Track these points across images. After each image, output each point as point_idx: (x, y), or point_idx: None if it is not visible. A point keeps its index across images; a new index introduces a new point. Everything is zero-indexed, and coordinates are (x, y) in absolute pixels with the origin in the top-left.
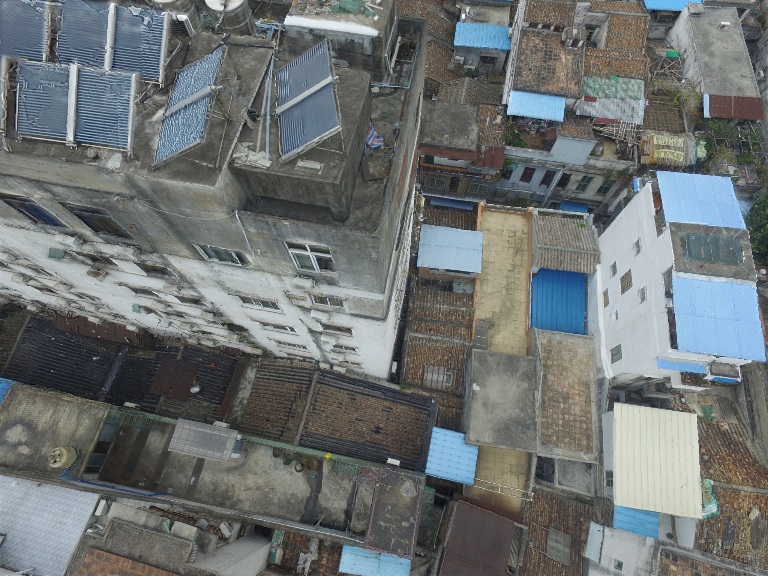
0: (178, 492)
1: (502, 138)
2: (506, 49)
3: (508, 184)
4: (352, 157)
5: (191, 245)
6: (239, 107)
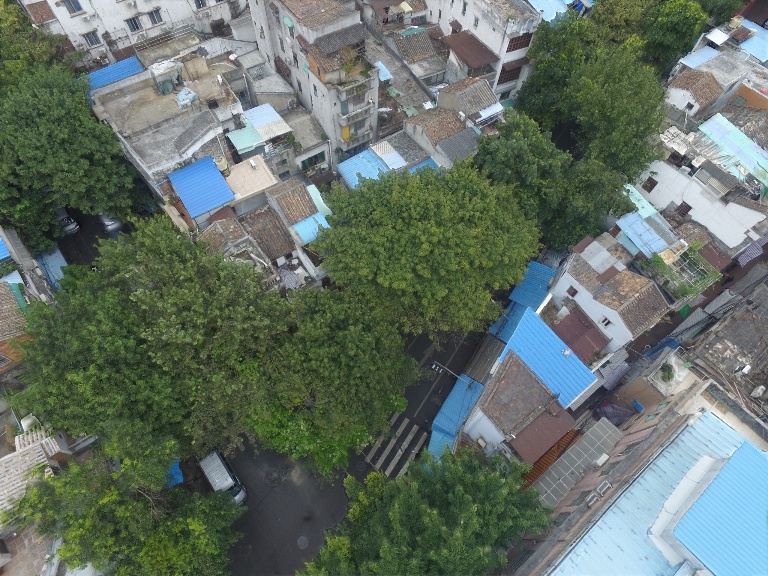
0: None
1: None
2: None
3: None
4: None
5: None
6: None
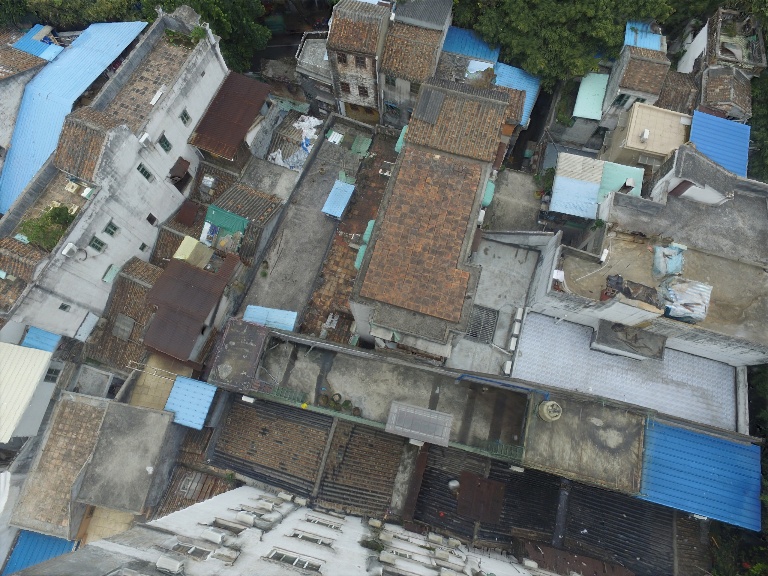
0: (449, 381)
1: None
2: None
3: None
4: None
5: None
6: None
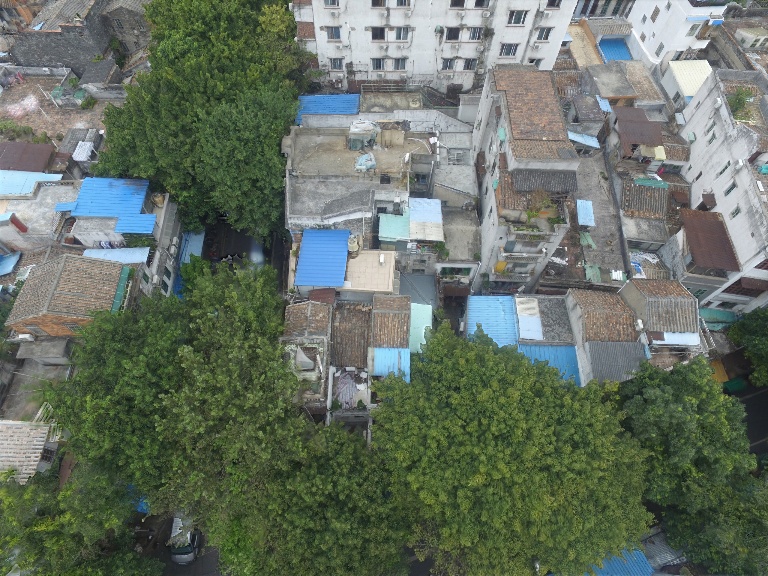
0: None
1: None
2: None
3: None
4: None
5: None
6: None
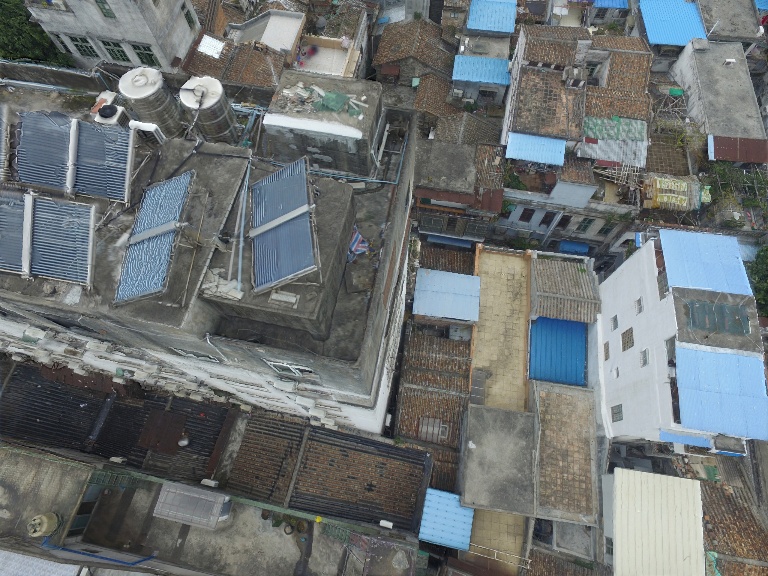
0: (164, 555)
1: (501, 180)
2: (506, 84)
3: (507, 223)
4: (332, 280)
5: (166, 347)
6: (210, 230)
